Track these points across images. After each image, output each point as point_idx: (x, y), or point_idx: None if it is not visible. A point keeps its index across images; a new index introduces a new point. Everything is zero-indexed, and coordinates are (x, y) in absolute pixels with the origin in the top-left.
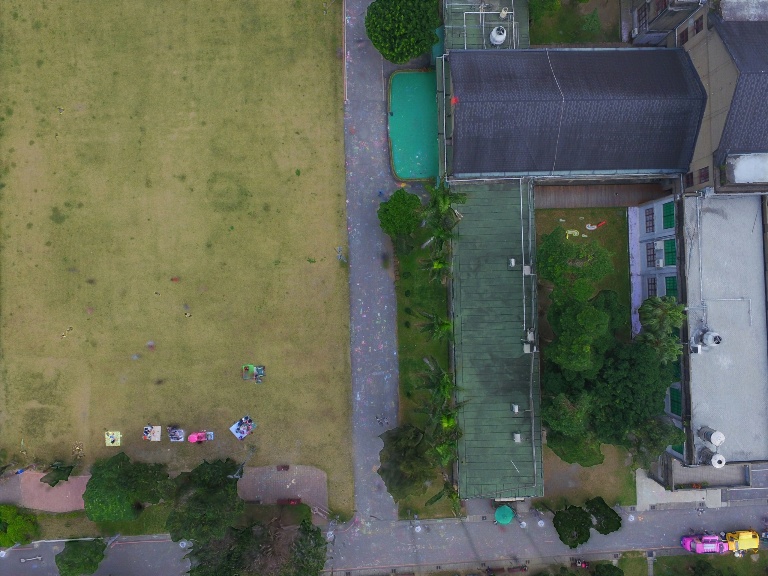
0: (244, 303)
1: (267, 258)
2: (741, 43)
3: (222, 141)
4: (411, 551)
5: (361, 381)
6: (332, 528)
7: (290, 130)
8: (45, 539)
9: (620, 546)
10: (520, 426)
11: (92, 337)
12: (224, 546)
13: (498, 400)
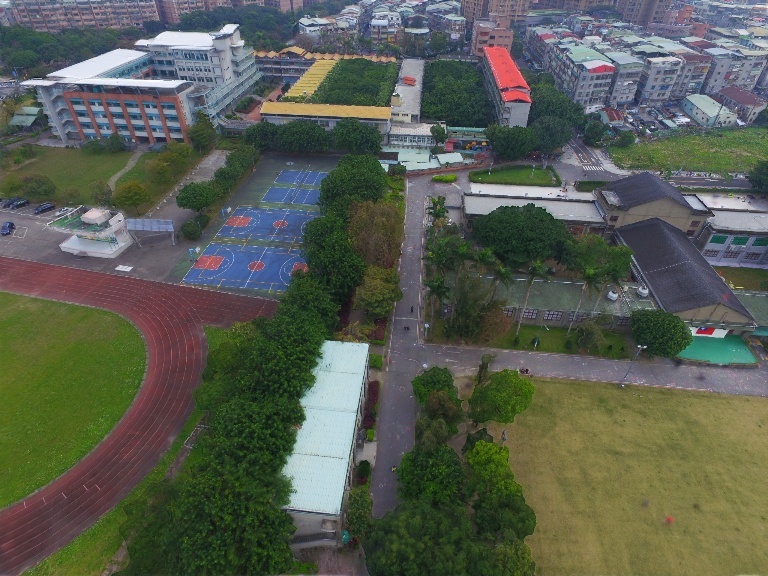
0: None
1: None
2: None
3: None
4: None
5: None
6: None
7: (761, 431)
8: None
9: None
10: None
11: None
12: None
13: None
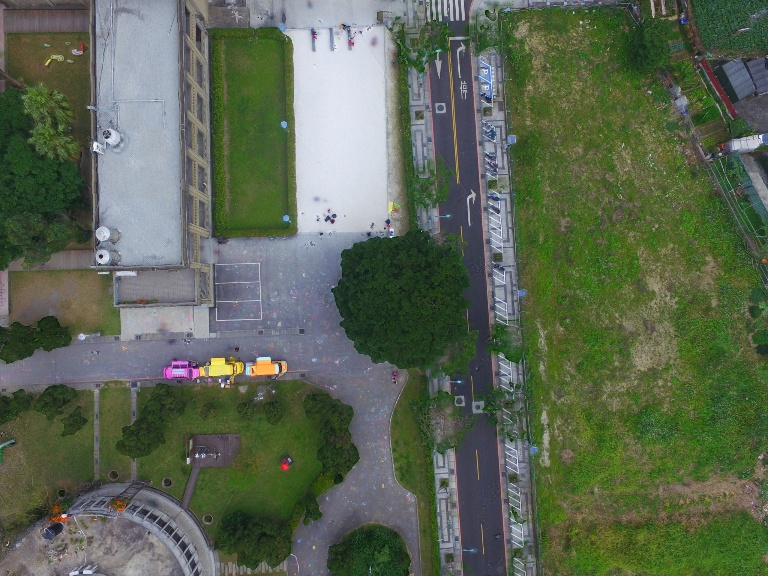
0: None
1: None
2: None
3: None
4: None
5: None
6: None
7: None
8: None
9: (102, 376)
10: None
11: None
12: None
13: None
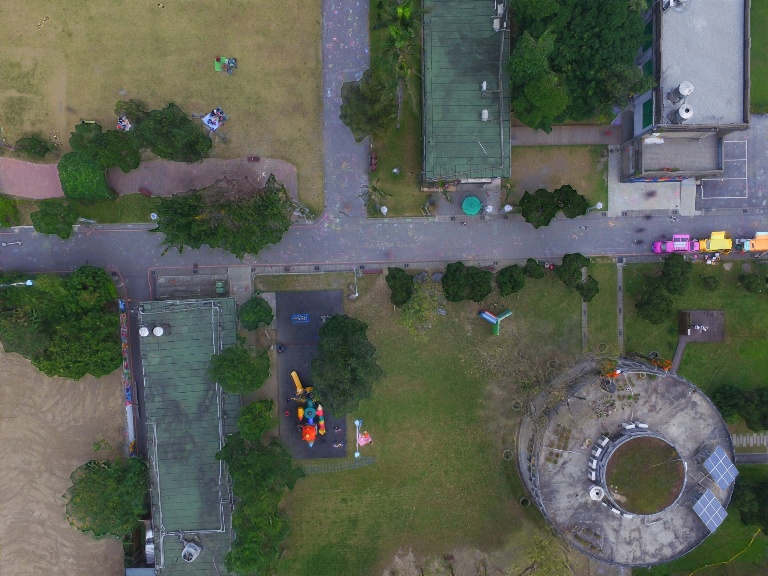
0: None
1: None
2: None
3: None
4: (379, 248)
5: (332, 78)
6: None
7: None
8: (25, 225)
9: (590, 251)
10: (488, 107)
11: (68, 27)
12: (190, 197)
13: (467, 80)
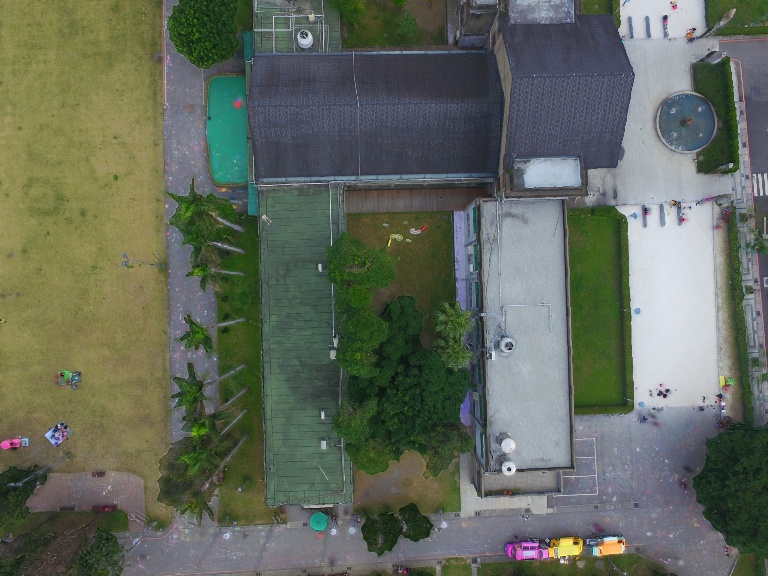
0: (60, 309)
1: (84, 263)
2: (522, 46)
3: (38, 146)
4: (230, 558)
5: None
6: (139, 535)
7: (108, 135)
8: None
9: (443, 553)
10: (329, 432)
11: None
12: (14, 554)
13: (307, 406)
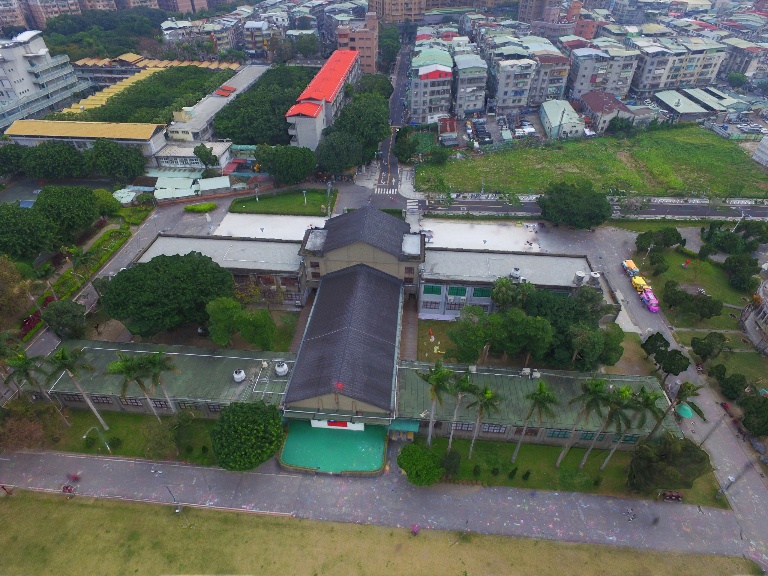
0: None
1: None
2: (340, 242)
3: None
4: (759, 500)
5: (594, 533)
6: None
7: None
8: None
9: (673, 344)
10: None
11: None
12: None
13: None
